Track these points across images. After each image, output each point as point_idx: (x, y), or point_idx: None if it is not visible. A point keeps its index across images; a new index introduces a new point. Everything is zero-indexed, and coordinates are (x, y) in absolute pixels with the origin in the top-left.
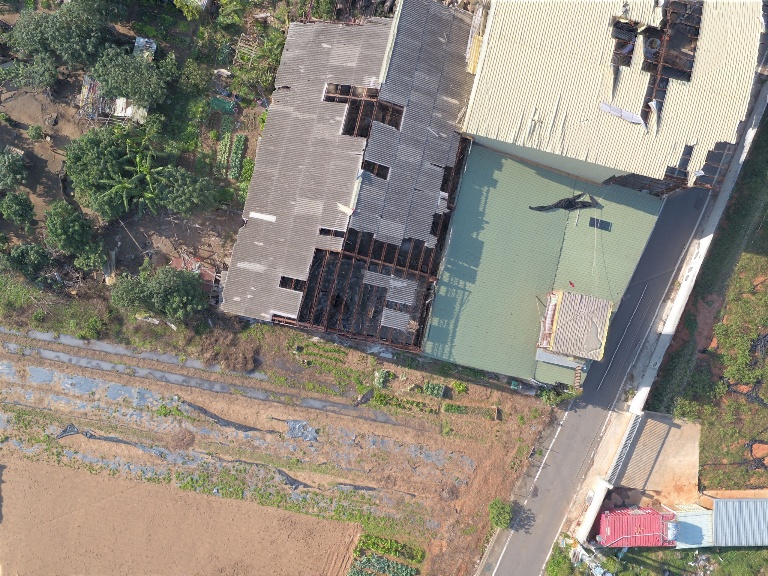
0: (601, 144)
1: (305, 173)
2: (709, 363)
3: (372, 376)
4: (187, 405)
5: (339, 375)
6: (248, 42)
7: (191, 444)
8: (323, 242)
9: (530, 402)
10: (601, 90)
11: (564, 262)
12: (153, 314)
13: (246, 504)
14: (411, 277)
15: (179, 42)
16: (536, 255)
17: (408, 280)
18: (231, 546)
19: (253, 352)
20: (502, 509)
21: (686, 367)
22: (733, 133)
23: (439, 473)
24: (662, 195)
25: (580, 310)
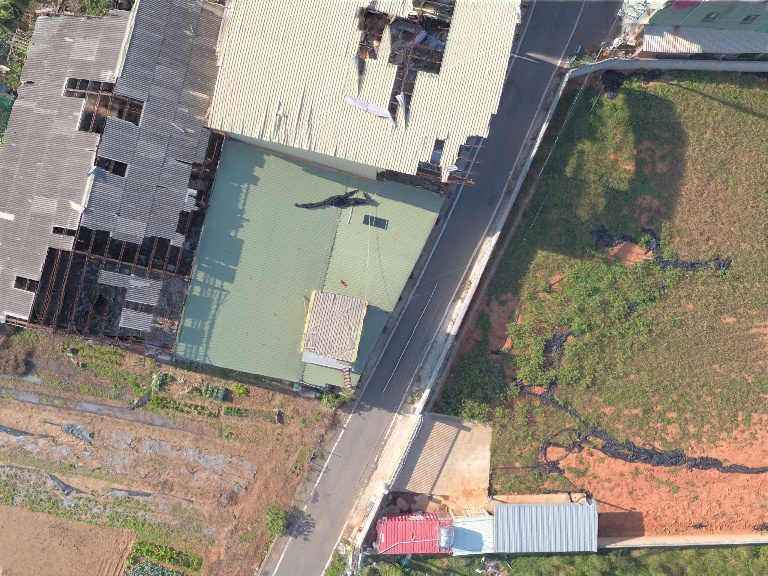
0: (349, 139)
1: (42, 170)
2: (502, 364)
3: (149, 379)
4: None
5: (115, 378)
6: (23, 37)
7: None
8: (56, 241)
9: (313, 405)
10: (347, 83)
11: (336, 261)
12: None
13: (16, 510)
14: (155, 277)
15: None
16: (304, 254)
17: (151, 280)
18: None
19: (25, 354)
20: (276, 515)
21: (476, 368)
22: (485, 127)
23: (218, 478)
24: (439, 191)
25: (333, 310)
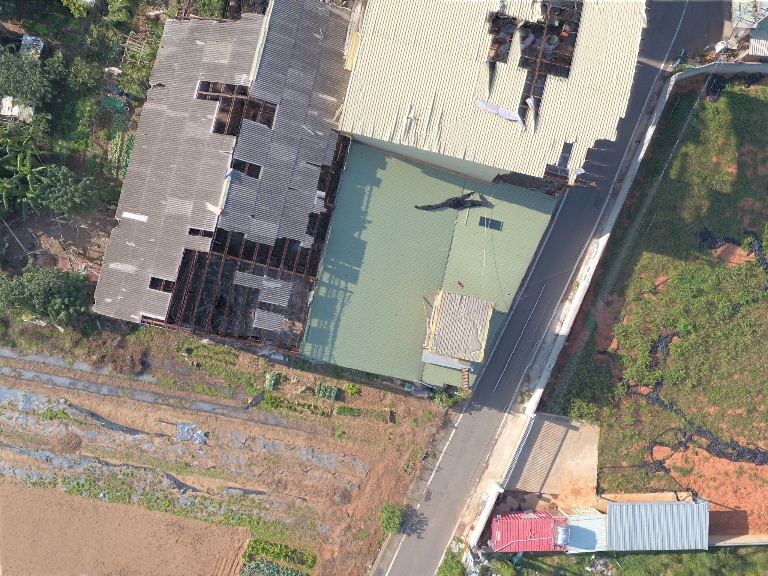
0: (479, 142)
1: (176, 172)
2: (609, 364)
3: (263, 378)
4: (74, 408)
5: (229, 377)
6: (137, 40)
7: (78, 448)
8: (192, 242)
9: (424, 404)
10: (477, 87)
11: (453, 262)
12: (39, 316)
13: (133, 509)
14: (286, 278)
15: (70, 40)
16: (423, 255)
17: (282, 281)
18: (117, 551)
19: (141, 354)
20: (392, 513)
21: (584, 368)
22: (613, 130)
23: (331, 477)
24: (554, 194)
25: (460, 311)
